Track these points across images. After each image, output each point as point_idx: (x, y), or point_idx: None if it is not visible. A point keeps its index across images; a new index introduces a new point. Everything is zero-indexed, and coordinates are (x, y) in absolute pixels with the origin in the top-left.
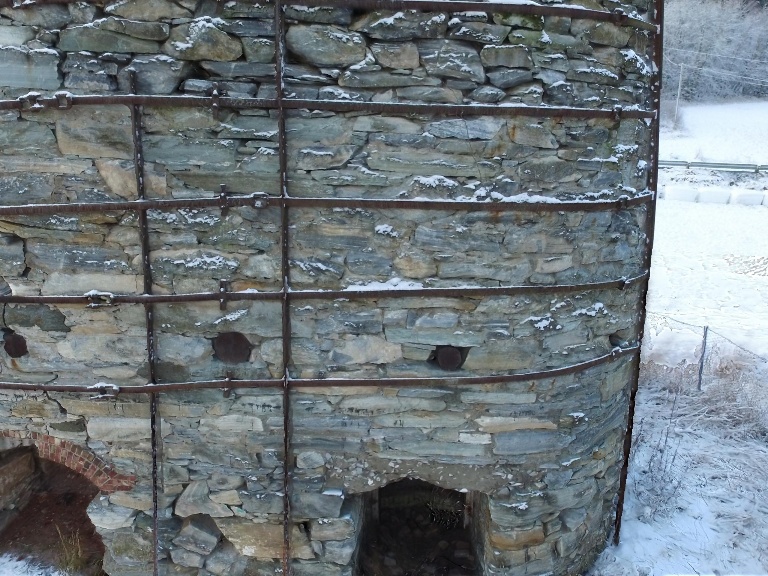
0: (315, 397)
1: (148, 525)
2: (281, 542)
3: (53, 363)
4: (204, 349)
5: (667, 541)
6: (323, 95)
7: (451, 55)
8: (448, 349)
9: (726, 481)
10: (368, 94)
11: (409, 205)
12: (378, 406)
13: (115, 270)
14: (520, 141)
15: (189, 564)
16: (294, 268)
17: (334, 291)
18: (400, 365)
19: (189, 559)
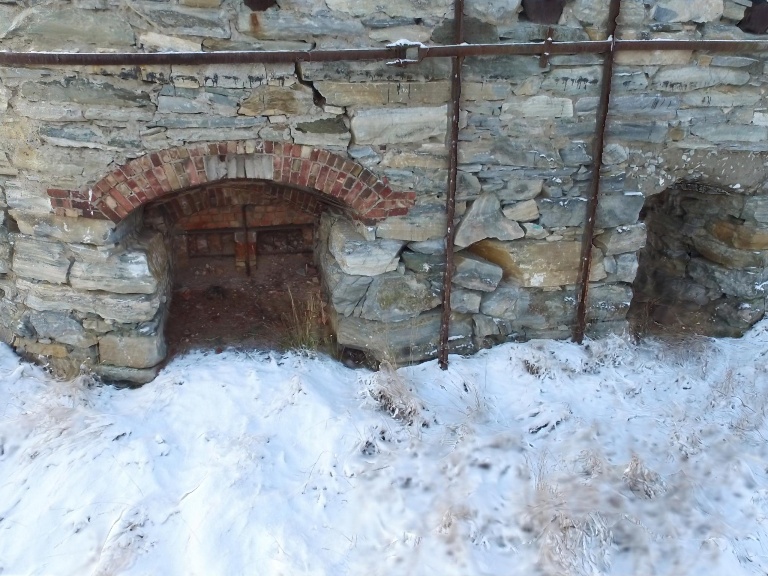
0: (632, 68)
1: (424, 261)
2: (574, 263)
3: (317, 19)
4: None
5: None
6: None
7: None
8: (764, 5)
9: None
10: None
11: None
12: (691, 79)
13: None
14: None
15: (469, 308)
16: None
17: None
18: (718, 25)
19: (469, 301)
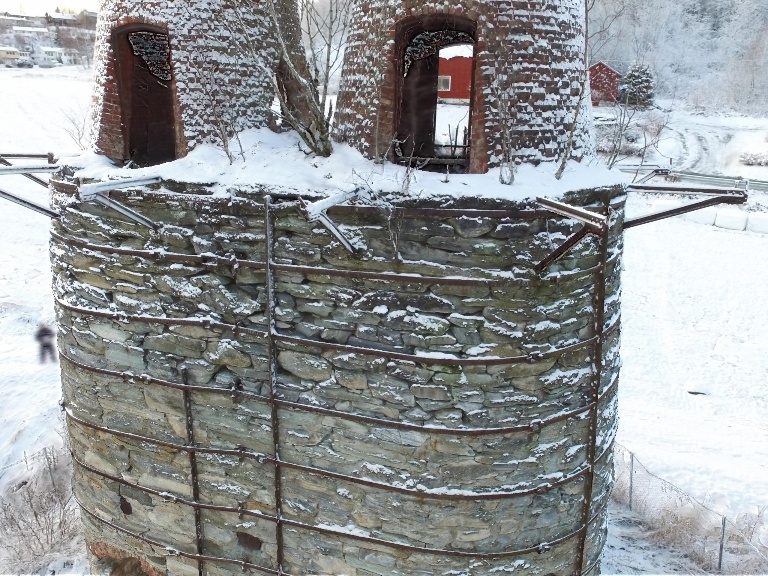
0: None
1: None
2: None
3: (146, 523)
4: (231, 538)
5: None
6: (302, 399)
7: (388, 387)
8: None
9: None
10: (332, 402)
11: (359, 482)
12: None
13: (178, 480)
14: (442, 450)
15: None
16: (284, 504)
17: (309, 525)
18: None
19: None
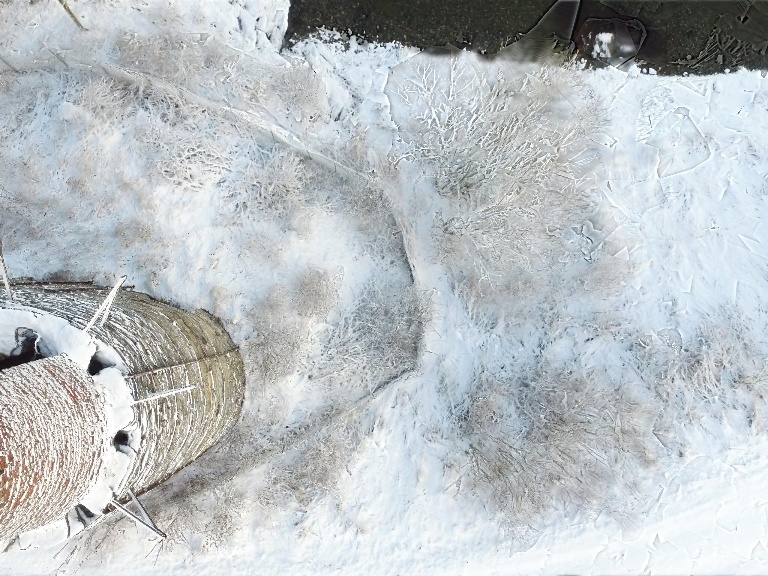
0: None
1: None
2: None
3: None
4: None
5: None
6: None
7: None
8: None
9: None
10: None
11: None
12: None
13: None
14: None
15: None
16: None
17: (16, 282)
18: None
19: None
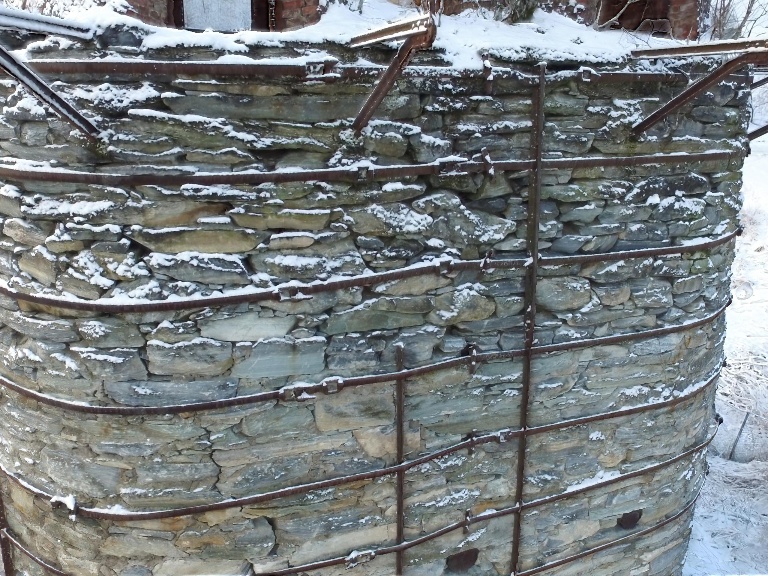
0: None
1: None
2: None
3: None
4: None
5: (701, 572)
6: (559, 337)
7: (655, 290)
8: (632, 514)
9: (701, 499)
10: (592, 330)
11: (618, 414)
12: (578, 571)
13: (368, 525)
14: (691, 346)
15: None
16: (526, 484)
17: (558, 495)
18: (597, 536)
19: None
